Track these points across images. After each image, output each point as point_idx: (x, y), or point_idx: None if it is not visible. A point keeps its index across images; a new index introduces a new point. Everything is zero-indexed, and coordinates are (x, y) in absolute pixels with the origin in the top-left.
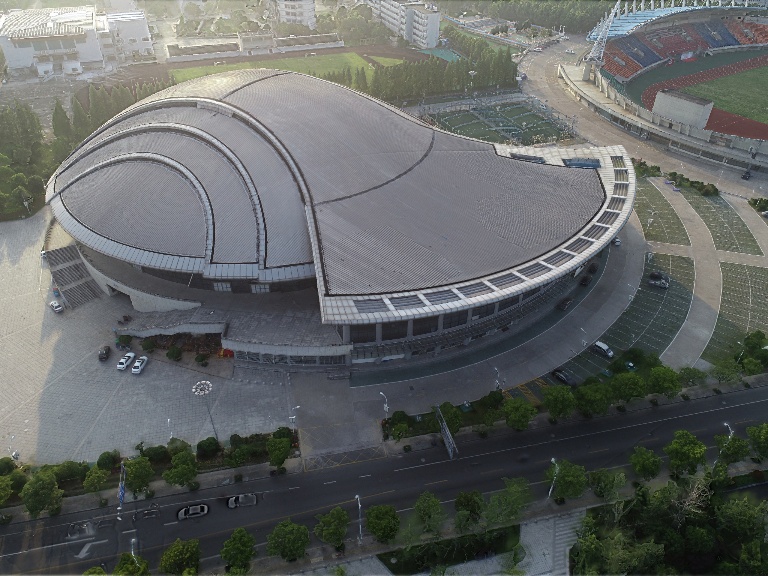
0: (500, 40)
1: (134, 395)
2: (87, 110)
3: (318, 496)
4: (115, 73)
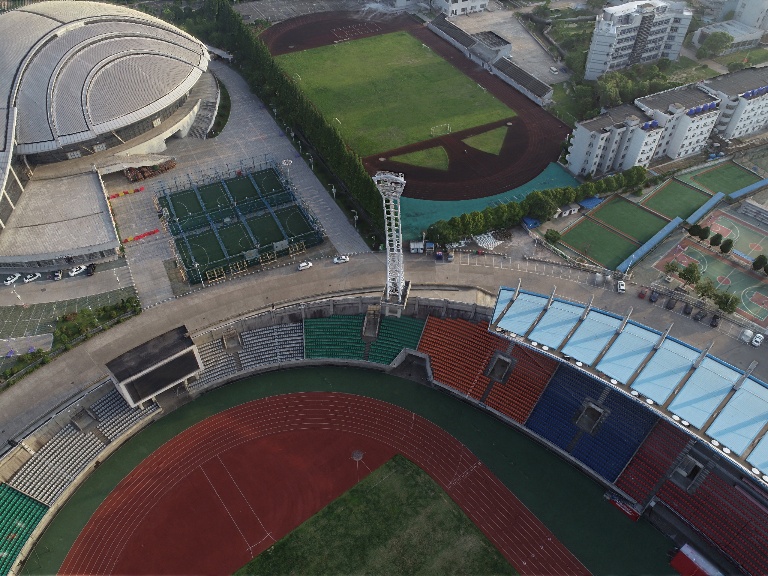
0: (673, 244)
1: None
2: (293, 22)
3: None
4: (386, 13)
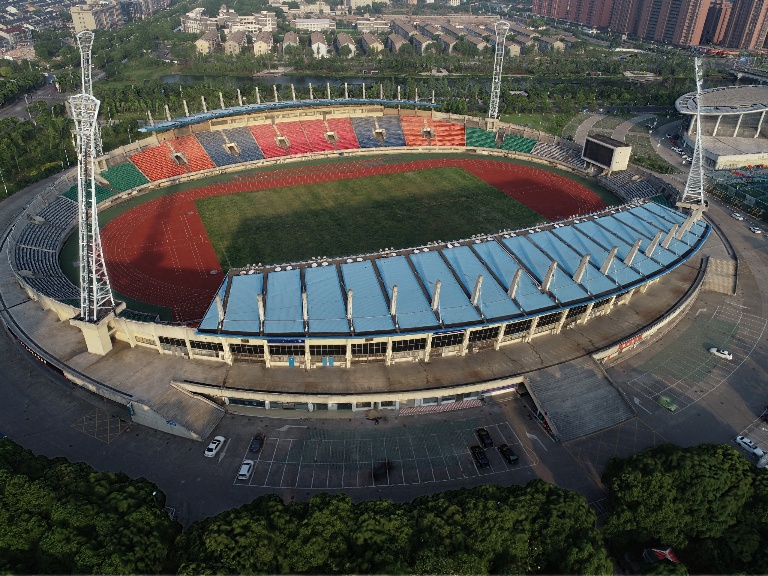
0: None
1: None
2: None
3: None
4: None
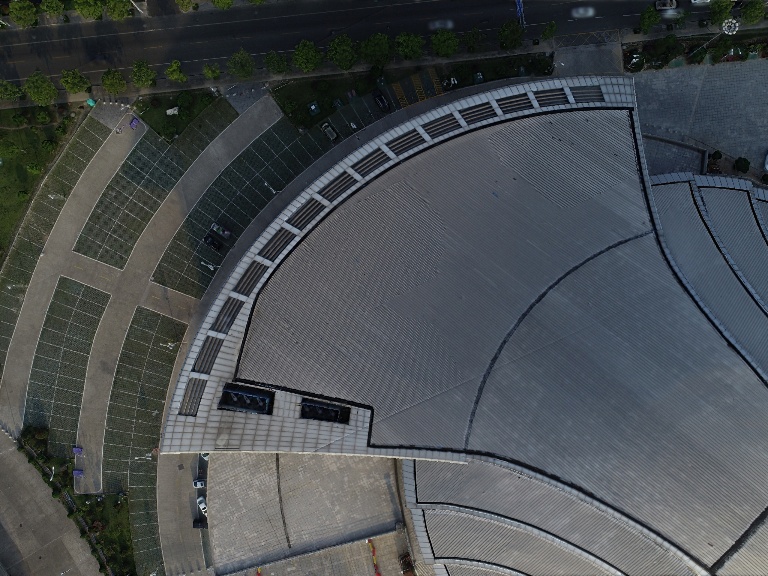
0: None
1: (767, 125)
2: None
3: (610, 4)
4: None
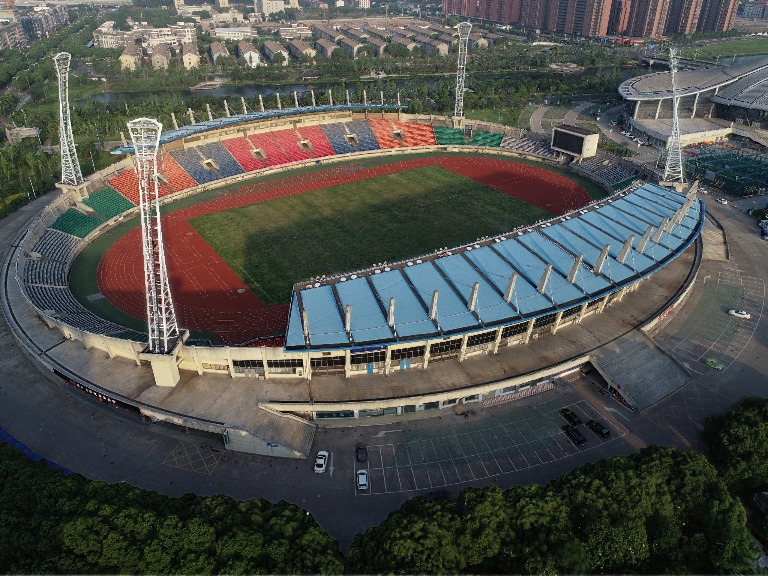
0: None
1: None
2: None
3: None
4: None
